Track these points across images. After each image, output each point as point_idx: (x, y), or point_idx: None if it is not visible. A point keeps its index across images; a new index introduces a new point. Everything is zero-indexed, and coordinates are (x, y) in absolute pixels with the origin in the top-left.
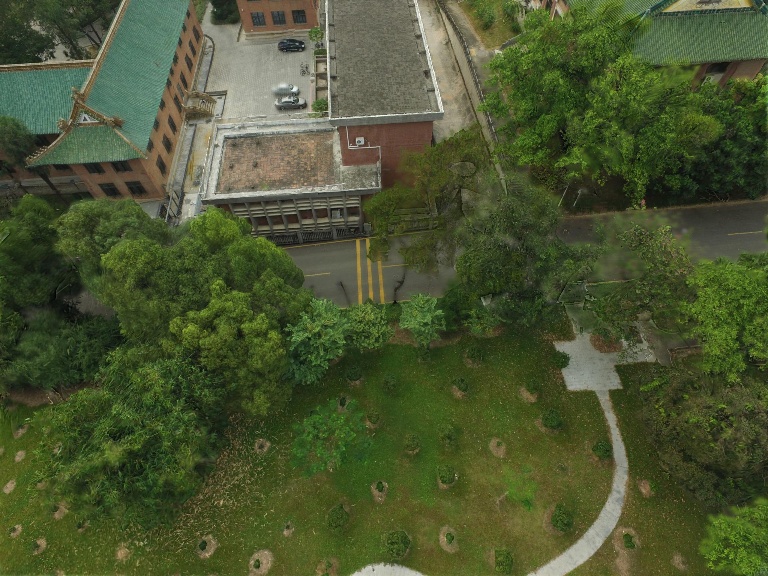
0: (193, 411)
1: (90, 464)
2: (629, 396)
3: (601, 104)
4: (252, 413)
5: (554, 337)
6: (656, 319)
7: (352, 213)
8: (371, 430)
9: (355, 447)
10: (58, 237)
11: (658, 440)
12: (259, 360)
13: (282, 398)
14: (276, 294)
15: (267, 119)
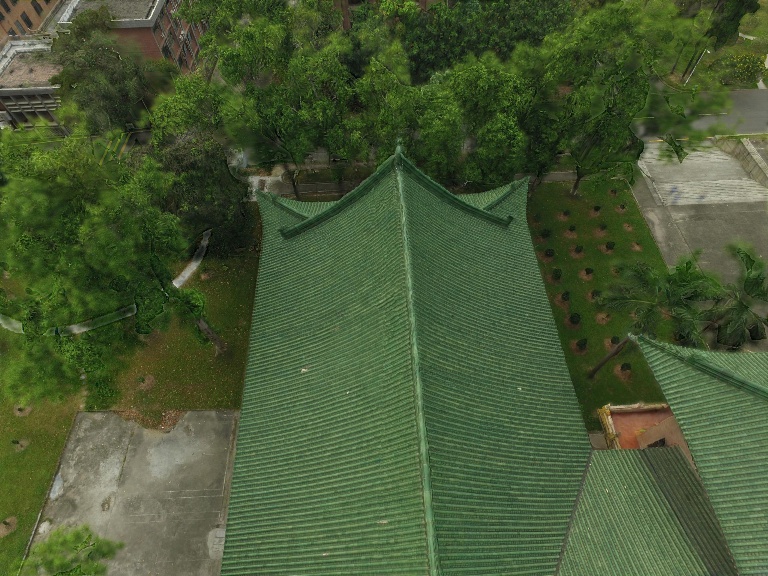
0: None
1: None
2: None
3: (225, 0)
4: None
5: None
6: (284, 176)
7: None
8: None
9: None
10: None
11: None
12: None
13: None
14: None
15: (51, 37)
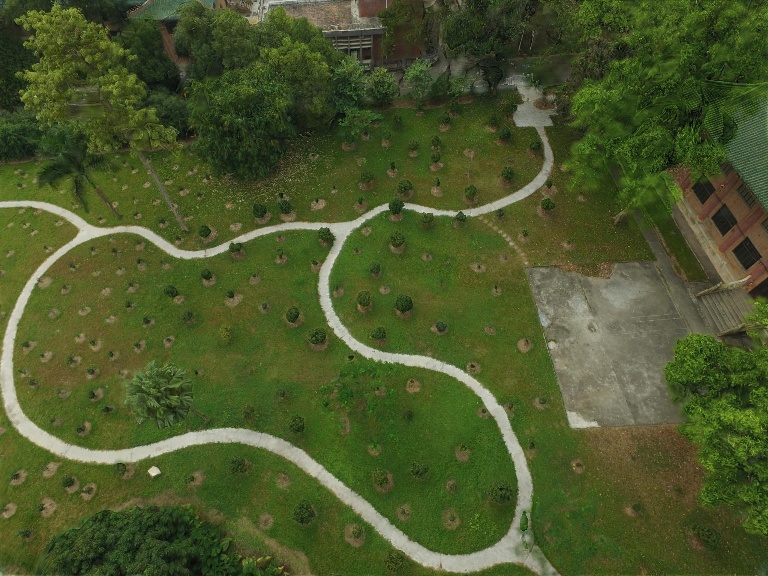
0: (281, 84)
1: (225, 100)
2: (557, 129)
3: None
4: (311, 112)
5: (509, 102)
6: None
7: (366, 56)
8: (385, 147)
9: (377, 130)
10: (178, 20)
11: (565, 114)
12: (317, 72)
13: (328, 113)
14: (324, 45)
15: None
